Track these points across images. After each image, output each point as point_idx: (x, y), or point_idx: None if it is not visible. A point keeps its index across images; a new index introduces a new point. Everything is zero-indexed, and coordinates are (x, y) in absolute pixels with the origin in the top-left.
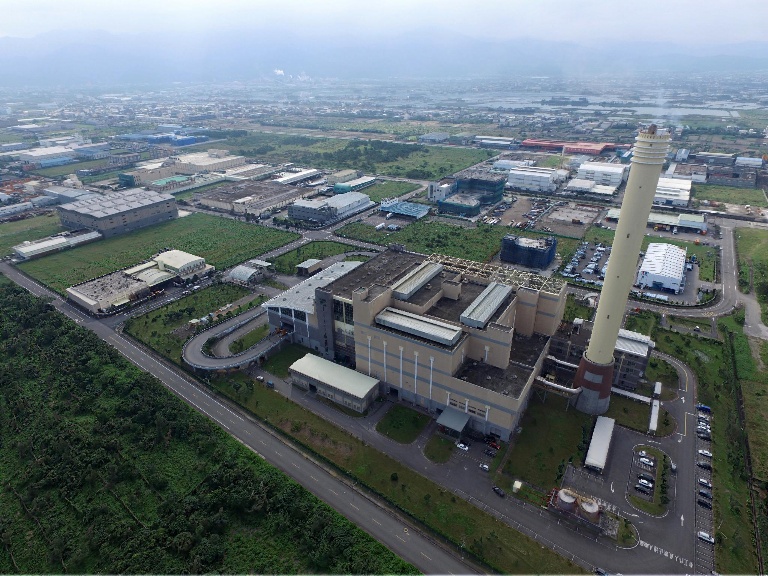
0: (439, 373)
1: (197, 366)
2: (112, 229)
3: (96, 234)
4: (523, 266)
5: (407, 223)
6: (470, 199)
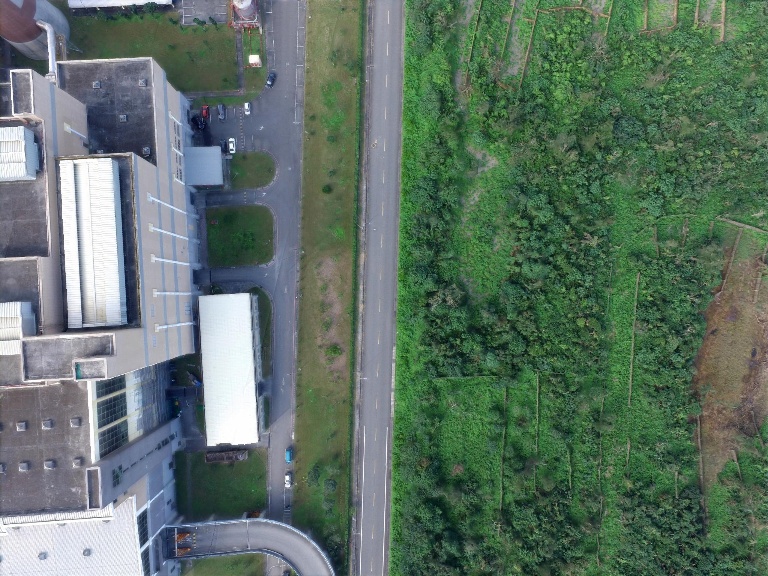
0: (160, 189)
1: None
2: None
3: None
4: None
5: None
6: None
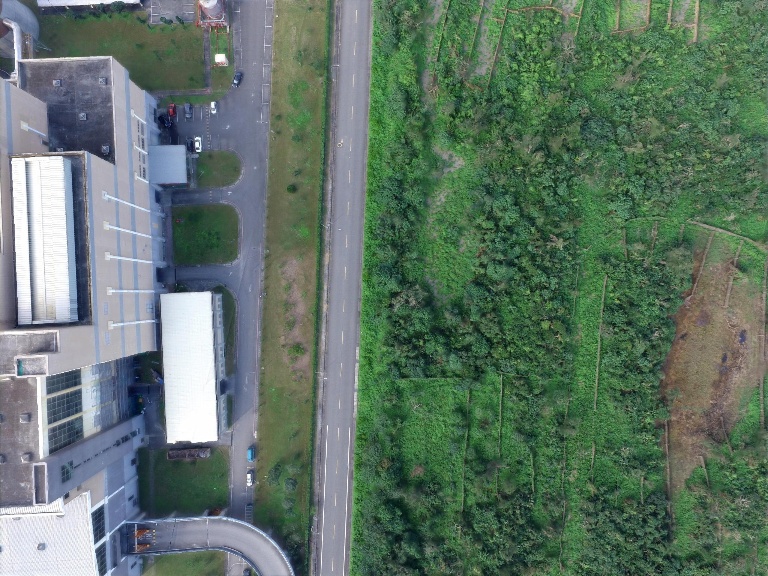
0: (118, 187)
1: None
2: None
3: None
4: None
5: None
6: None
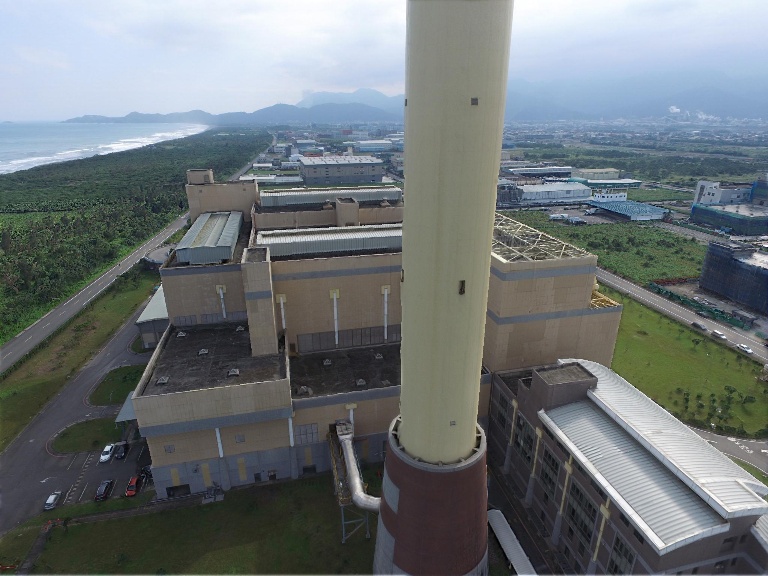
0: None
1: (144, 254)
2: (314, 178)
3: (299, 179)
4: (738, 306)
5: (608, 222)
6: (762, 211)
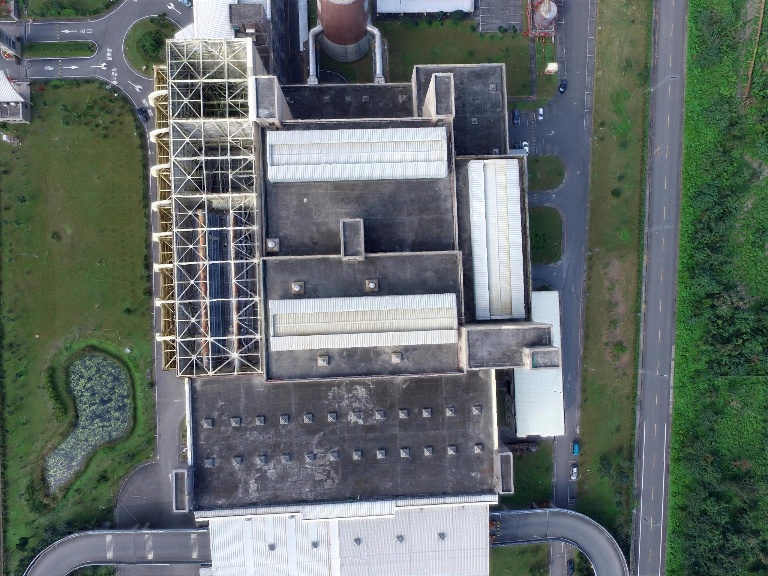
0: None
1: None
2: None
3: None
4: None
5: None
6: None
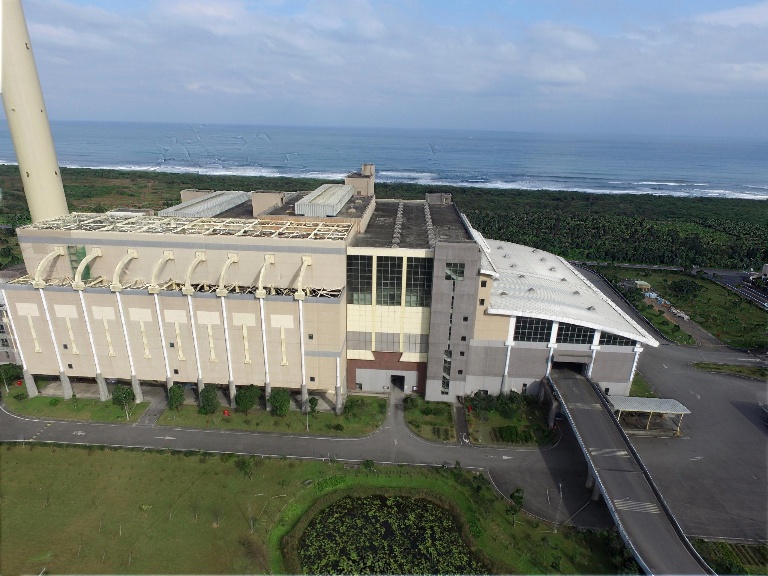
0: None
1: None
2: None
3: None
4: None
5: None
6: None
